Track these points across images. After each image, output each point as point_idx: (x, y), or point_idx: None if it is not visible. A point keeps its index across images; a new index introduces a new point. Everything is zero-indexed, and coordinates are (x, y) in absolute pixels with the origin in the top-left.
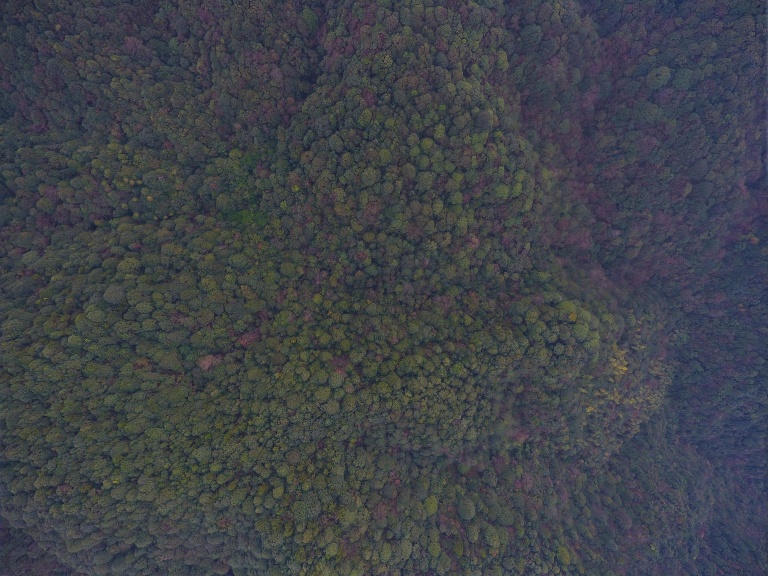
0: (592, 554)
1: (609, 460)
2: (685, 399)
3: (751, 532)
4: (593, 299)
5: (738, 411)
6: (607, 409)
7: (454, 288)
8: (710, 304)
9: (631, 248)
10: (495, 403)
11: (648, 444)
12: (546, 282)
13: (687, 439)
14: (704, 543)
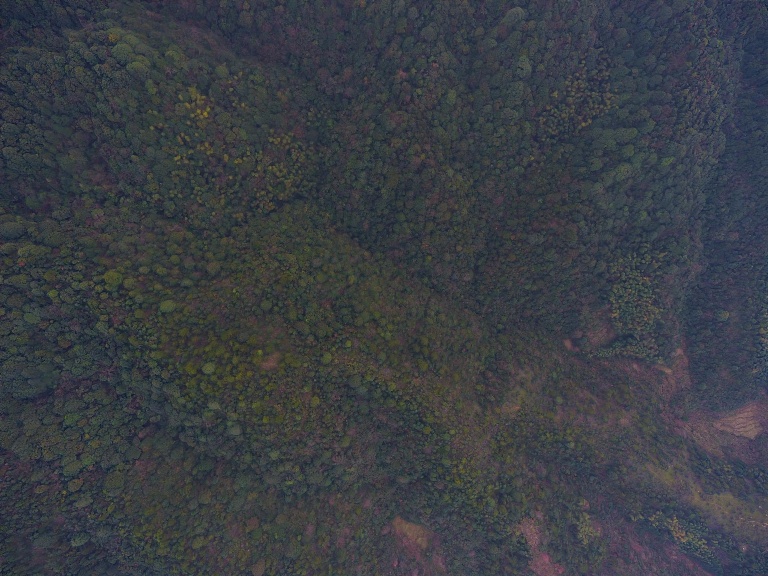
0: (155, 285)
1: (230, 228)
2: (329, 182)
3: (388, 310)
4: (164, 39)
5: (367, 186)
6: (200, 161)
7: (14, 21)
8: (345, 83)
9: (241, 12)
10: (48, 130)
11: (278, 218)
12: (110, 17)
13: (344, 229)
14: (329, 313)
